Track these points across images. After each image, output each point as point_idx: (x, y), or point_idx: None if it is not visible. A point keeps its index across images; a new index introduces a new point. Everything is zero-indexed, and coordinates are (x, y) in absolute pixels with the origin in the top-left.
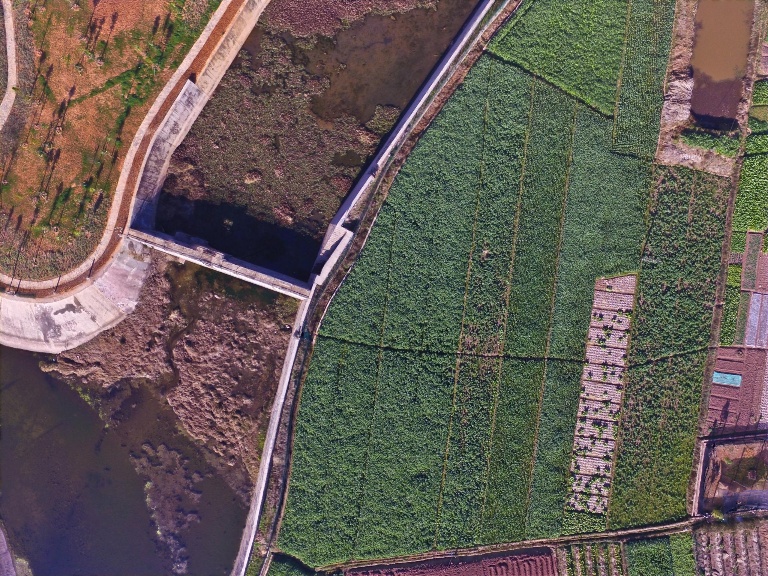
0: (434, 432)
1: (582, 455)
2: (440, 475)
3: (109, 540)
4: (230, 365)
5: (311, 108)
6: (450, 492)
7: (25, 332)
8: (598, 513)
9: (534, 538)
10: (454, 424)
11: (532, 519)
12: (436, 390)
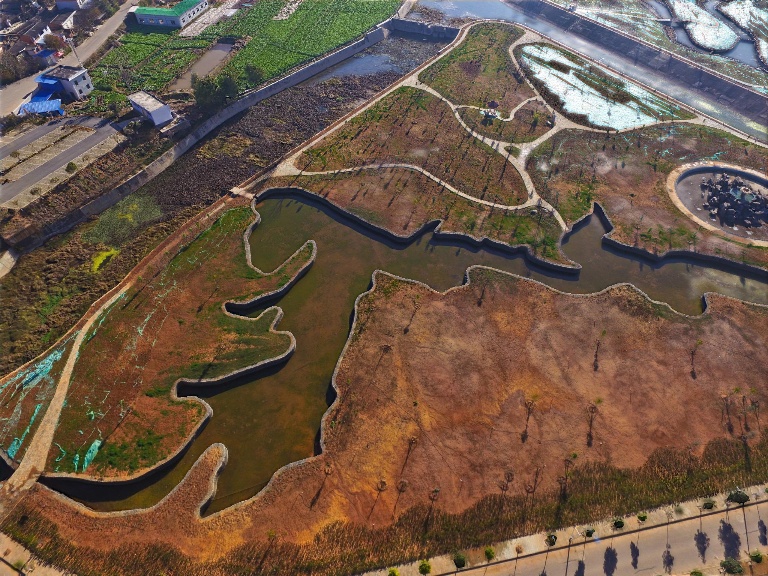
0: None
1: None
2: None
3: None
4: None
5: (391, 58)
6: None
7: None
8: None
9: None
10: (345, 2)
11: None
12: (350, 6)
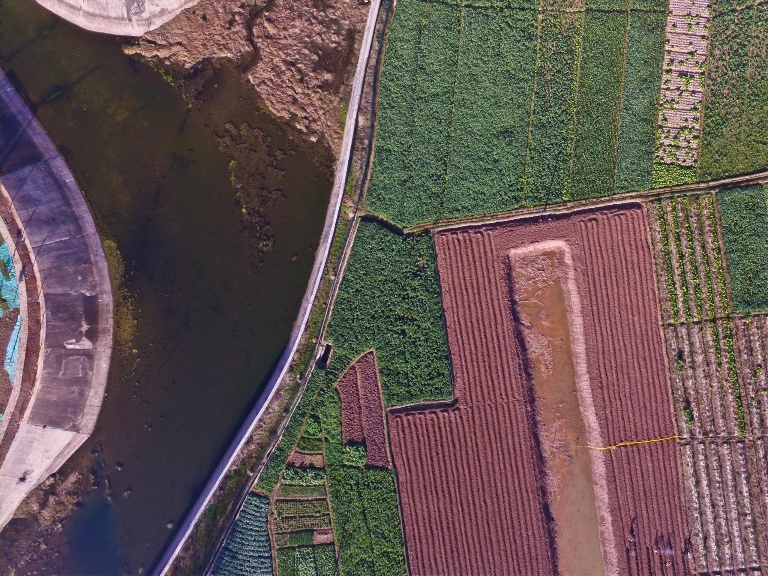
0: (519, 86)
1: (669, 108)
2: (526, 130)
3: (195, 221)
4: (310, 41)
5: None
6: (537, 147)
7: (109, 9)
8: (688, 166)
9: (624, 191)
10: (539, 78)
11: (621, 170)
12: (519, 44)
